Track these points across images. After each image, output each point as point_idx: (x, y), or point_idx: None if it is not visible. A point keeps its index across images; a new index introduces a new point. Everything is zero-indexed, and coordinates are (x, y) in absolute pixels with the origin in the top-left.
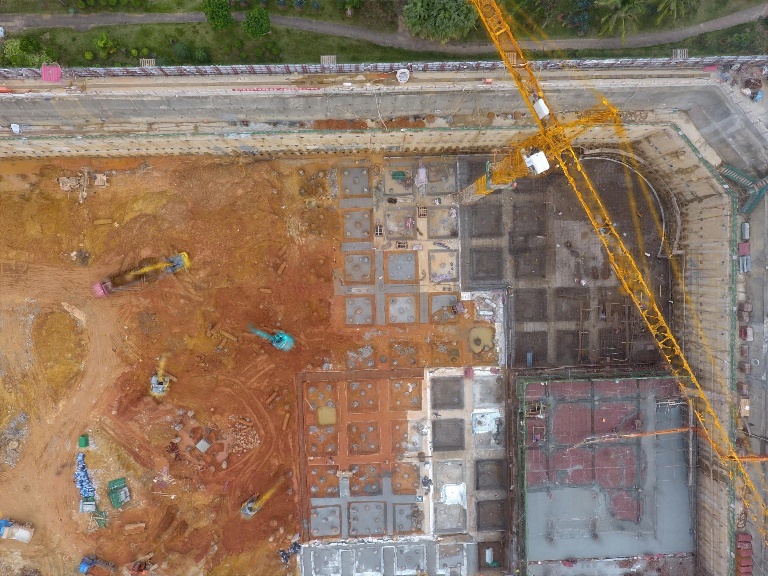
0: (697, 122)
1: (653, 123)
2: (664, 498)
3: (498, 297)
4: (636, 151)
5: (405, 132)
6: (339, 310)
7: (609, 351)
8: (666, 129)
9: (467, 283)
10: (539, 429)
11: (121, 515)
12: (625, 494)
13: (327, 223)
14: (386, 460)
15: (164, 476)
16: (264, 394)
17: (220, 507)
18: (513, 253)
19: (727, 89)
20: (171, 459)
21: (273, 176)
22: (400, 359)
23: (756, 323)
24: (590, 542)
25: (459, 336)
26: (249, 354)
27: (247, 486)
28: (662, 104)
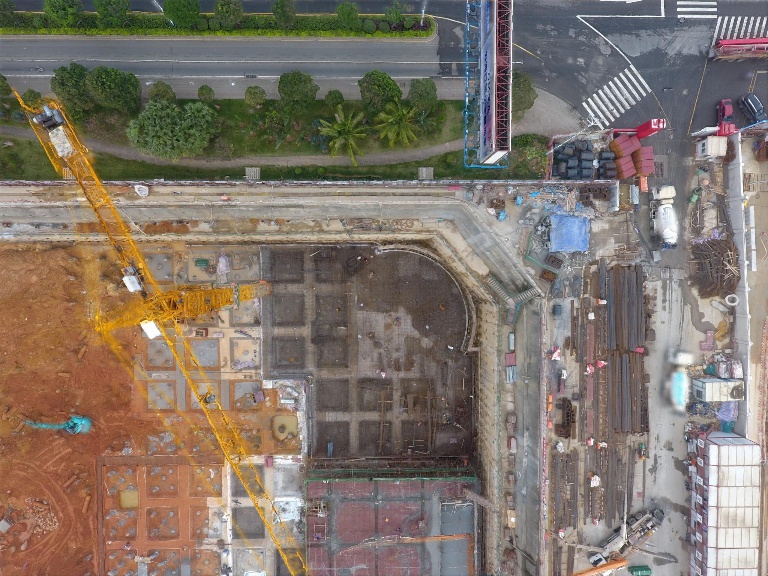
0: (462, 232)
1: (419, 232)
2: None
3: (302, 385)
4: (428, 249)
5: (168, 236)
6: (140, 395)
7: (411, 443)
8: (435, 237)
9: (268, 371)
10: (321, 527)
11: None
12: None
13: (128, 309)
14: (184, 547)
15: None
16: (62, 477)
17: None
18: (315, 343)
19: (470, 209)
20: None
21: (71, 263)
22: (202, 445)
23: (519, 435)
24: None
25: (260, 424)
26: (46, 438)
27: (45, 568)
28: (423, 215)
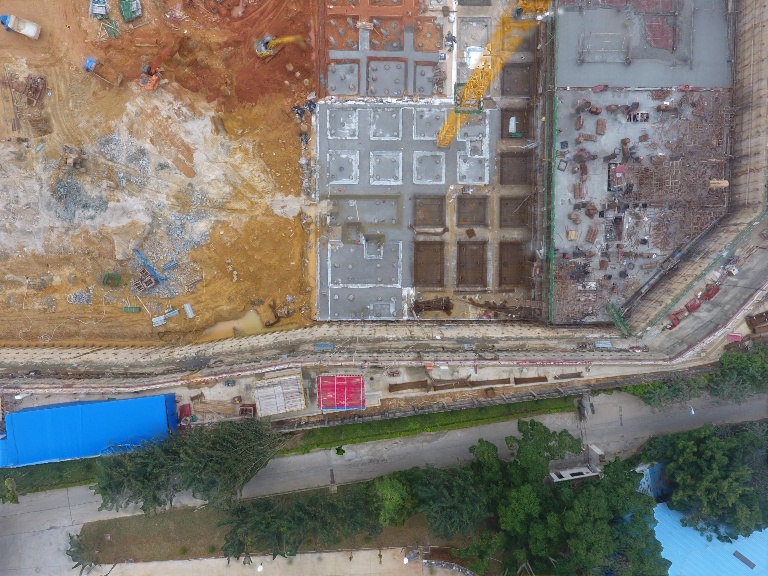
0: None
1: None
2: (701, 31)
3: None
4: None
5: None
6: None
7: None
8: None
9: None
10: None
11: (132, 31)
12: (661, 20)
13: None
14: (409, 11)
15: (177, 12)
16: None
17: (234, 55)
18: None
19: None
20: (185, 0)
21: None
22: None
23: None
24: (622, 70)
25: None
26: None
27: (263, 34)
28: None
